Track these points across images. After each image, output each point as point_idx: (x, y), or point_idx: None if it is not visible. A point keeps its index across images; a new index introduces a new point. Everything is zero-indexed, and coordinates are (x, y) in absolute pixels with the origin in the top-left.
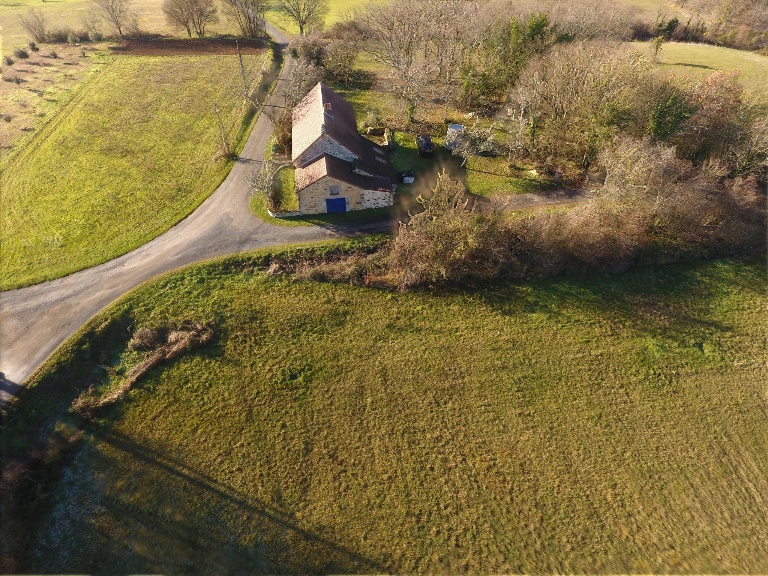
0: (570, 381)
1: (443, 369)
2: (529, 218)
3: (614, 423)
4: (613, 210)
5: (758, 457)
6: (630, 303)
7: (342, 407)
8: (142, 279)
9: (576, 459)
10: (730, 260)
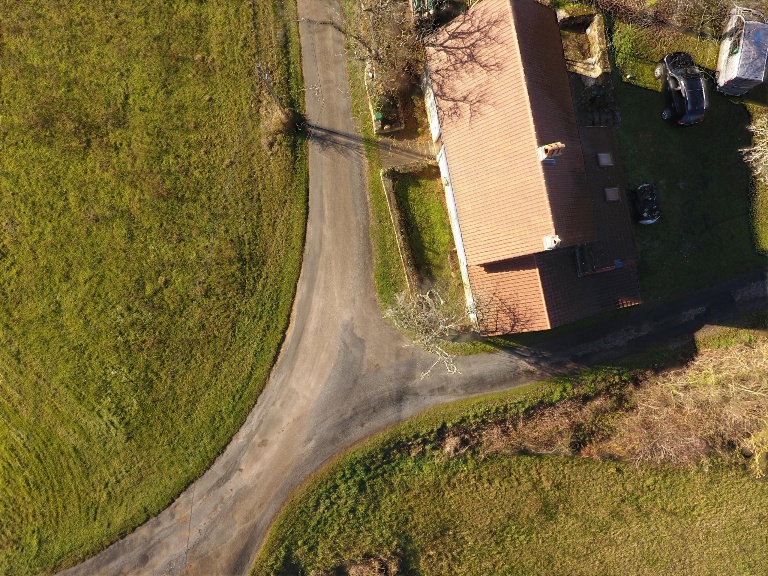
0: None
1: (672, 561)
2: None
3: None
4: None
5: None
6: None
7: None
8: (281, 499)
9: None
10: None
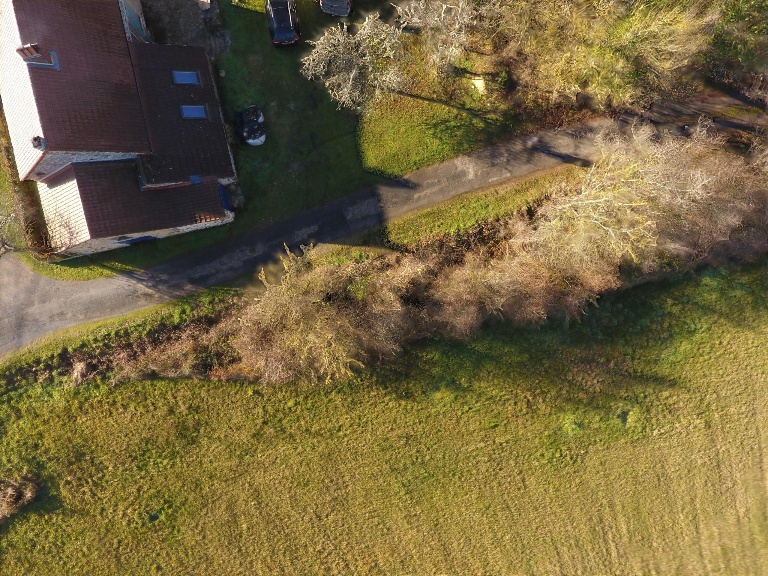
0: (465, 476)
1: (323, 482)
2: (451, 233)
3: (501, 512)
4: (576, 258)
5: (632, 521)
6: (562, 364)
7: (216, 540)
8: None
9: (456, 548)
10: (725, 269)
